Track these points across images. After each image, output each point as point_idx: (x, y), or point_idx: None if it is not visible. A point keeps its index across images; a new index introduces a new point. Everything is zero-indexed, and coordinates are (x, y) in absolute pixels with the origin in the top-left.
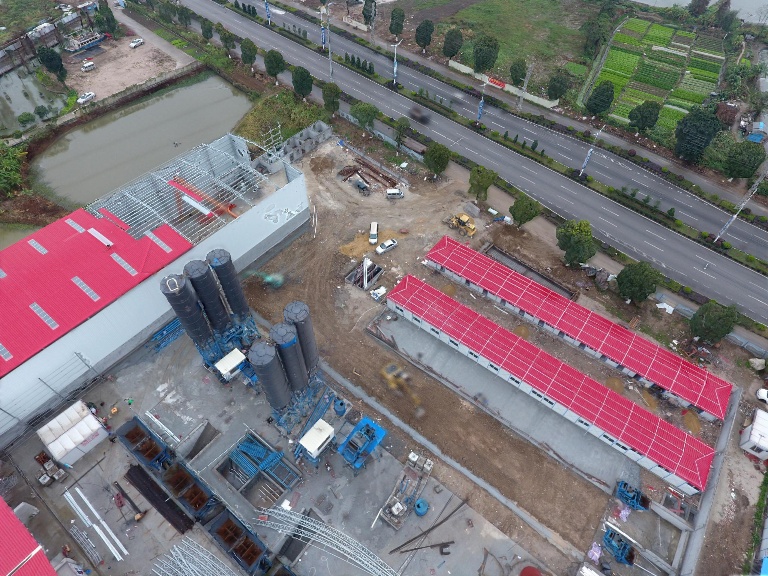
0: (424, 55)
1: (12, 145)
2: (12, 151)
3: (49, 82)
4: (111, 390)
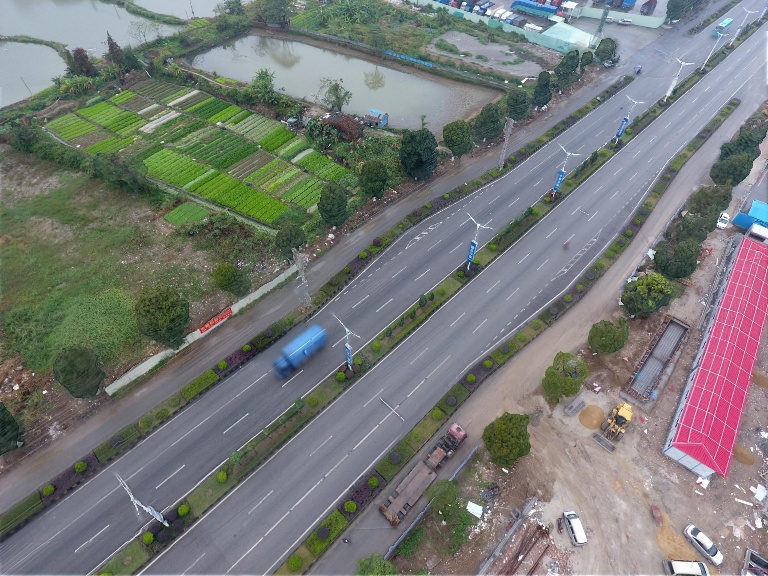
0: (34, 445)
1: None
2: None
3: None
4: None
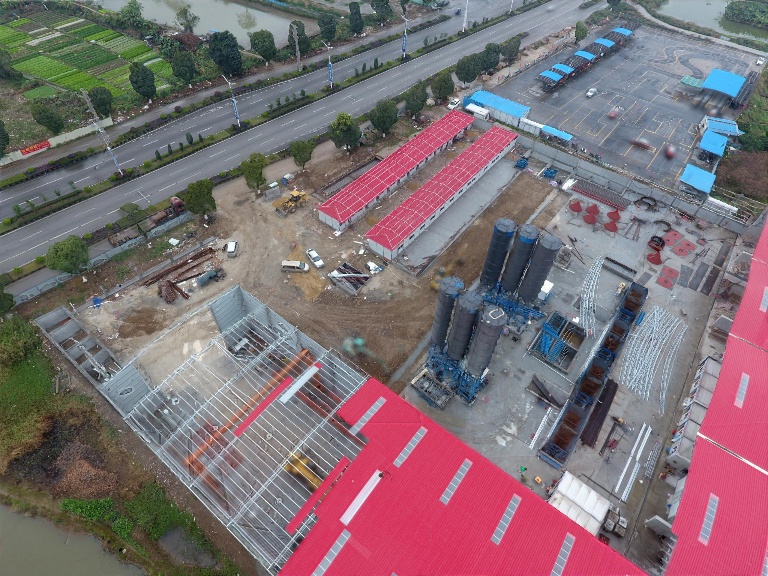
0: None
1: None
2: None
3: None
4: None
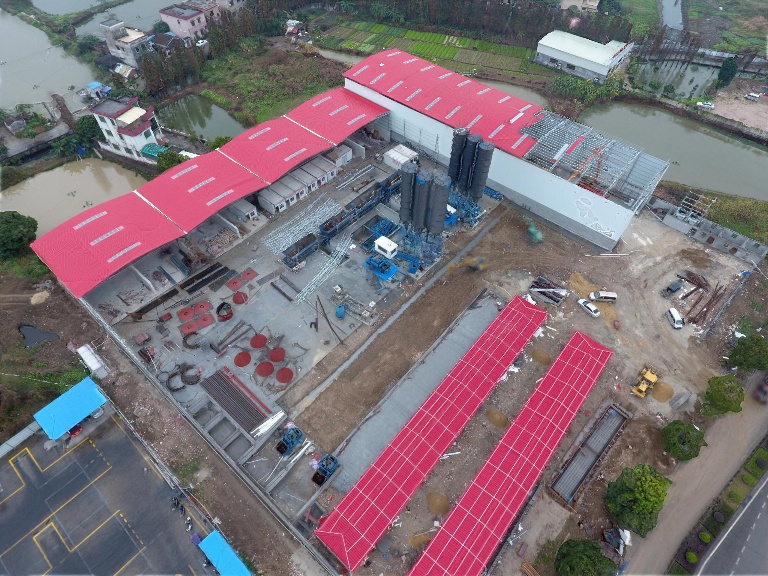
0: None
1: (625, 89)
2: (614, 87)
3: (712, 84)
4: (428, 168)
